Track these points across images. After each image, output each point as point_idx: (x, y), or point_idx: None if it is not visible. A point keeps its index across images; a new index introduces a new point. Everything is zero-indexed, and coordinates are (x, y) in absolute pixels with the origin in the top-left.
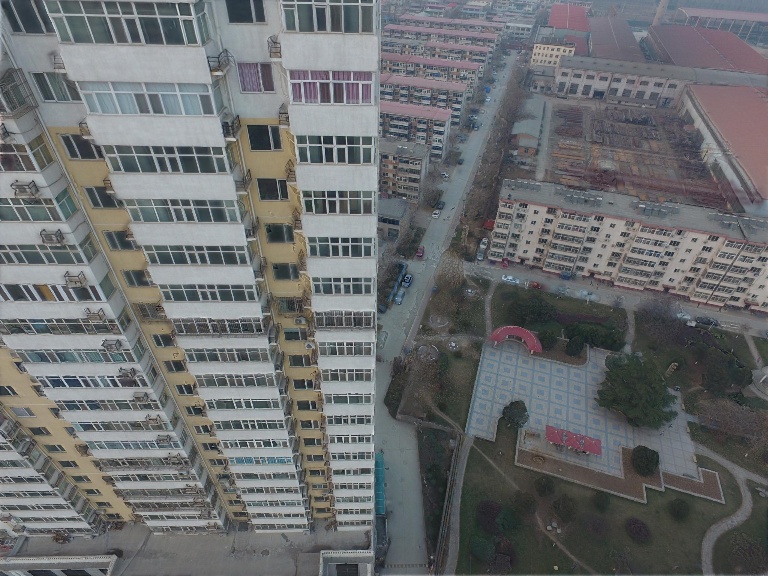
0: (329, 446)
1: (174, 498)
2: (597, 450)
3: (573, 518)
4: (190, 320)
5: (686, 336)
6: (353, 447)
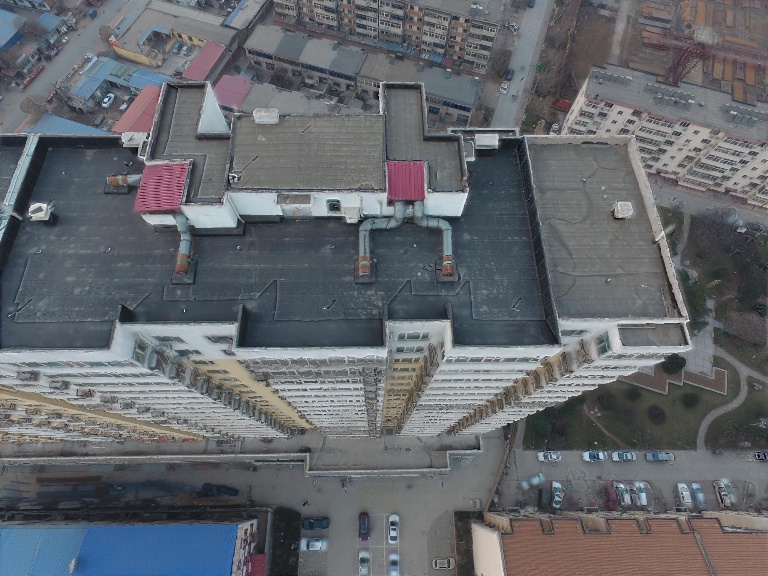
0: (481, 422)
1: (357, 433)
2: None
3: (612, 409)
4: None
5: (733, 244)
6: (497, 422)
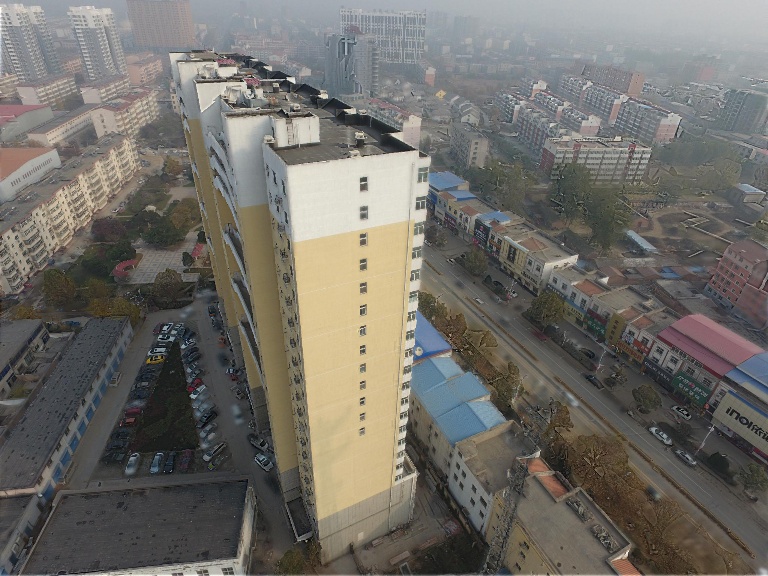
0: None
1: None
2: (202, 244)
3: None
4: None
5: None
6: None
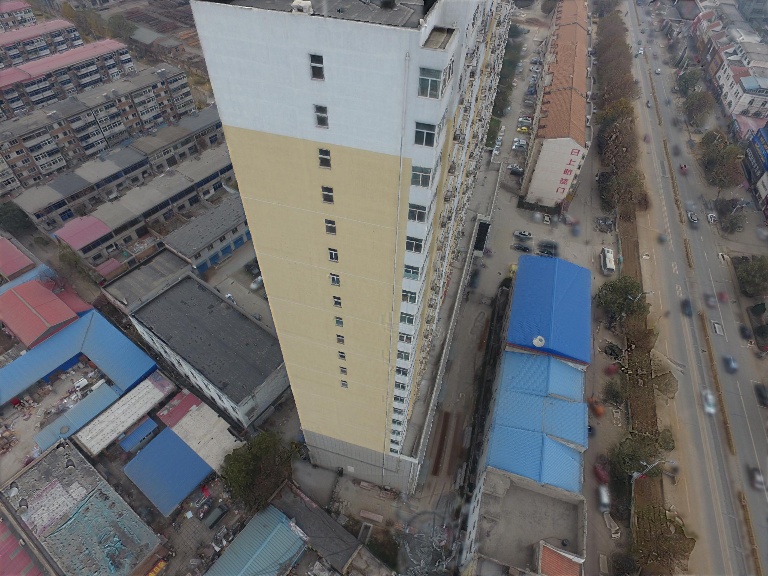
0: None
1: None
2: None
3: None
4: (508, 19)
5: None
6: None
